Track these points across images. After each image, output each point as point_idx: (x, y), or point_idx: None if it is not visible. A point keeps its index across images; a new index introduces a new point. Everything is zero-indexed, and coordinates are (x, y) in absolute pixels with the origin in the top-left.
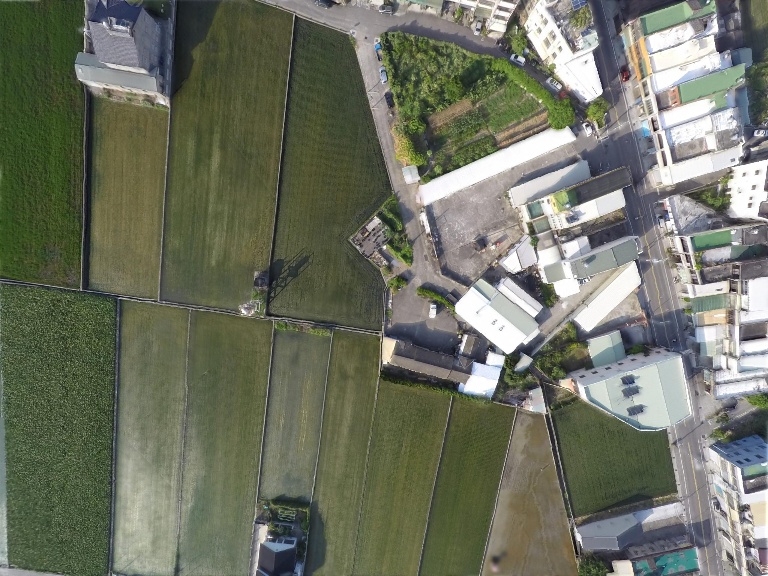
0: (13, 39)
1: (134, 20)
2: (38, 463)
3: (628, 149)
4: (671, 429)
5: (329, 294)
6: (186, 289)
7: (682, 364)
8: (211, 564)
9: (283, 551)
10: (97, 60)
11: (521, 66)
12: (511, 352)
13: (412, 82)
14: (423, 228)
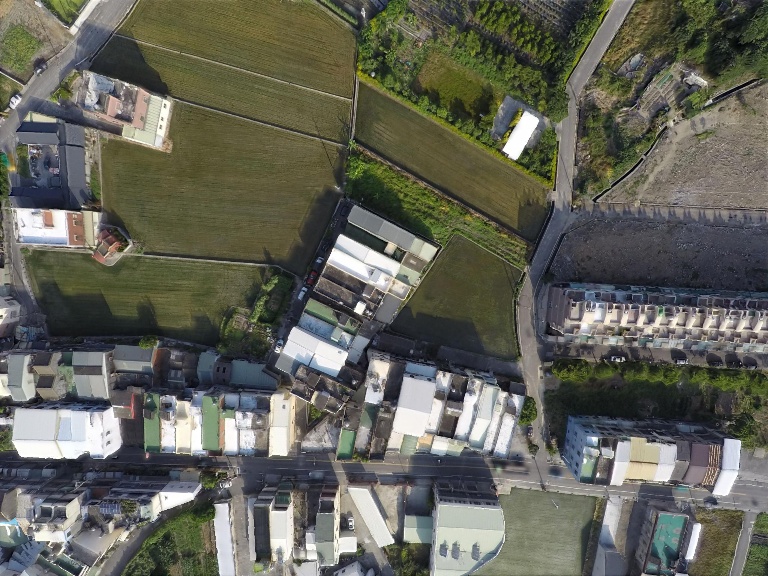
0: None
1: None
2: None
3: None
4: (527, 486)
5: None
6: None
7: (448, 506)
8: None
9: None
10: None
11: (161, 516)
12: None
13: None
14: None
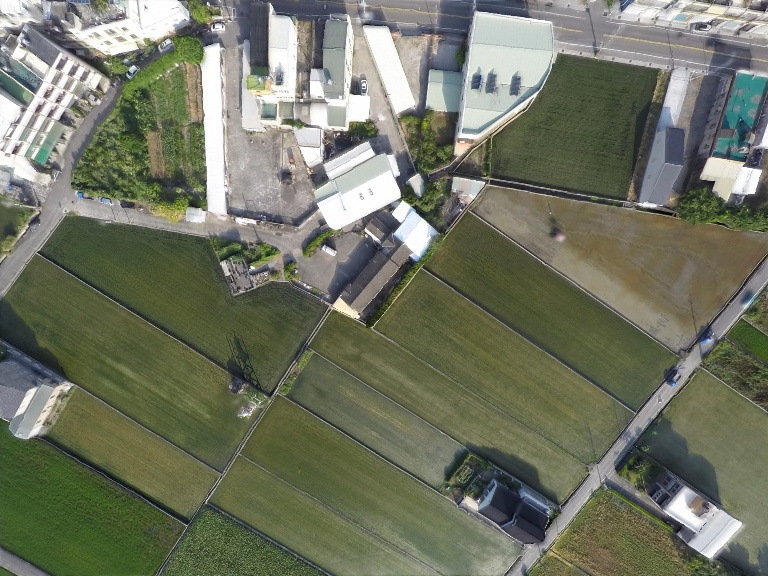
0: None
1: None
2: None
3: None
4: (577, 50)
5: (275, 336)
6: (221, 449)
7: (486, 13)
8: (481, 562)
9: (493, 497)
10: (17, 419)
11: None
12: (400, 193)
13: None
14: (250, 225)
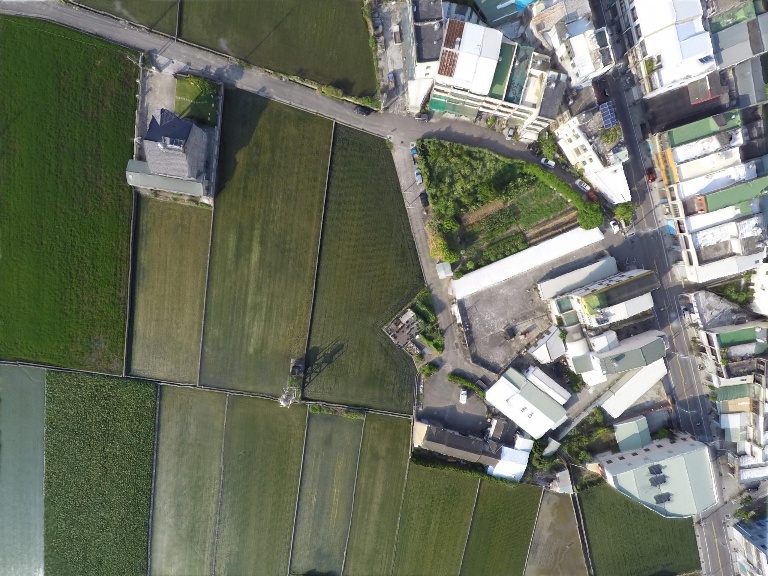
0: (67, 145)
1: (186, 137)
2: (77, 540)
3: (654, 245)
4: None
5: (362, 380)
6: (224, 374)
7: (708, 455)
8: None
9: None
10: (147, 167)
11: (551, 168)
12: (539, 438)
13: (446, 184)
14: (454, 318)
